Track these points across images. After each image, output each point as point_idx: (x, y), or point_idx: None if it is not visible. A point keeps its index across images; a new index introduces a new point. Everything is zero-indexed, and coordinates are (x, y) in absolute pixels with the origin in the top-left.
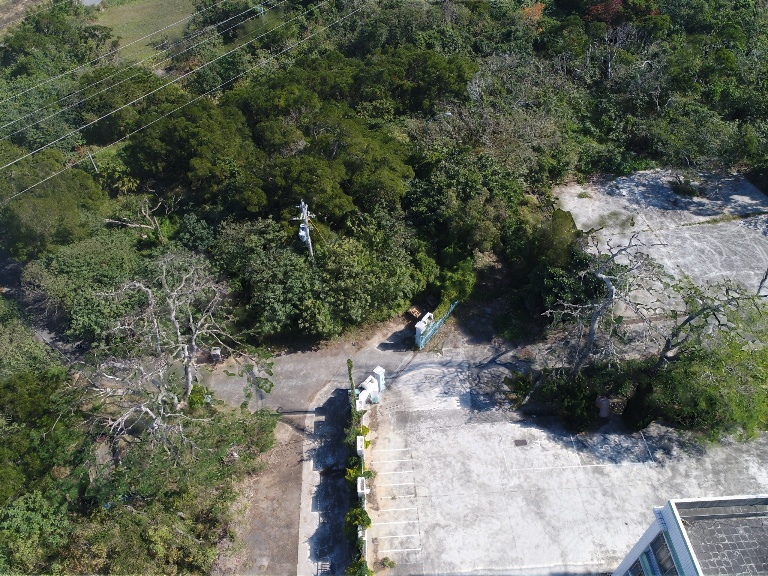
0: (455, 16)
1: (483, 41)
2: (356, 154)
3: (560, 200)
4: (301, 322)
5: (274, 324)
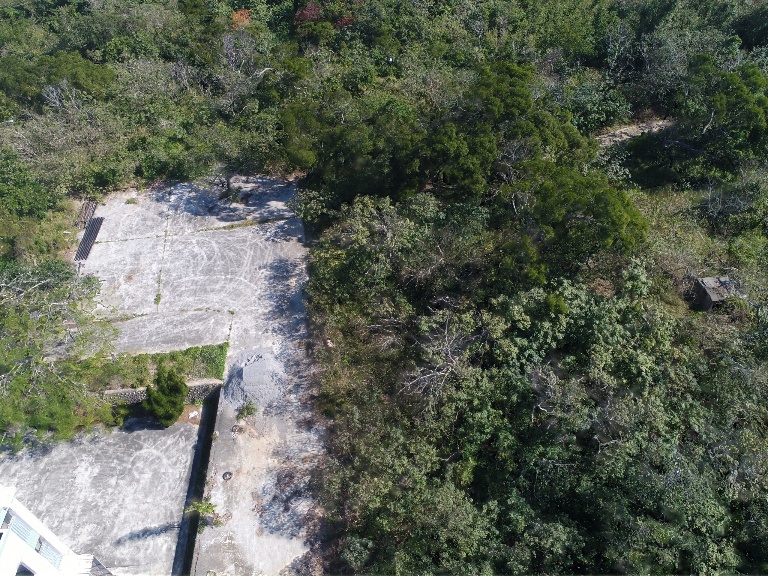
0: (163, 22)
1: (170, 47)
2: None
3: (106, 206)
4: None
5: None
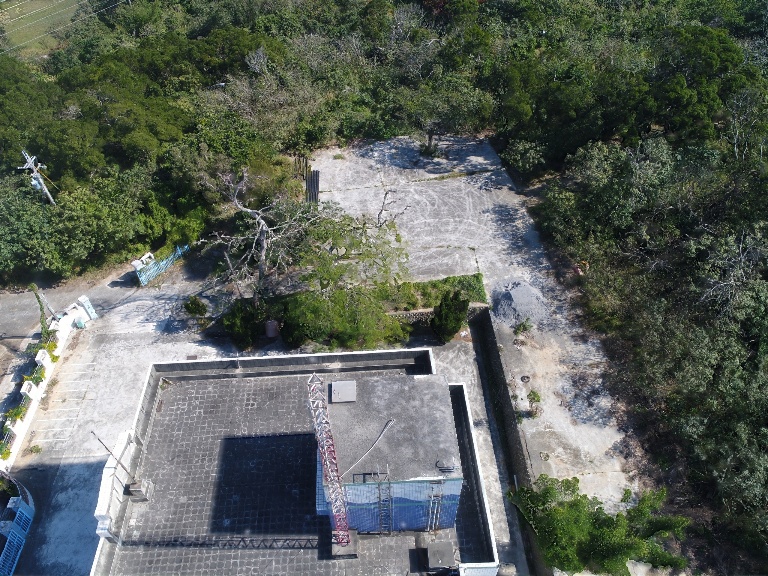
0: (300, 2)
1: (316, 24)
2: (118, 118)
3: (316, 161)
4: (29, 260)
5: (8, 262)
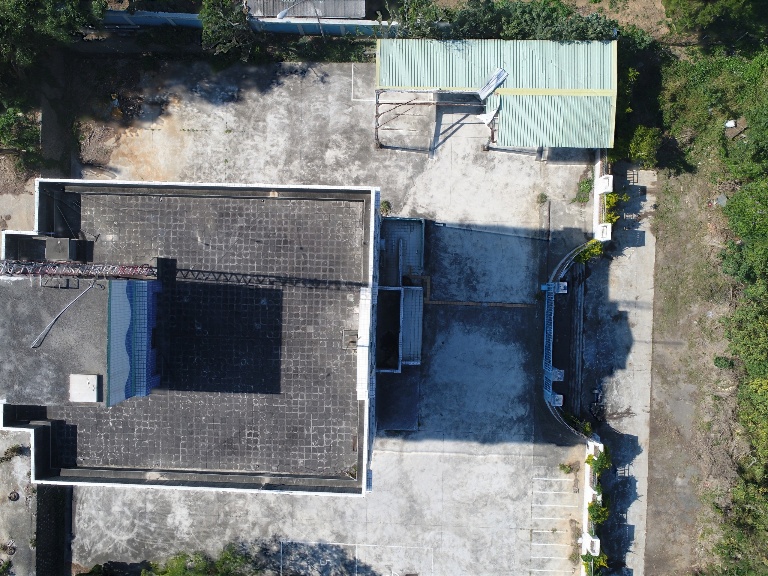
0: None
1: None
2: None
3: None
4: None
5: None
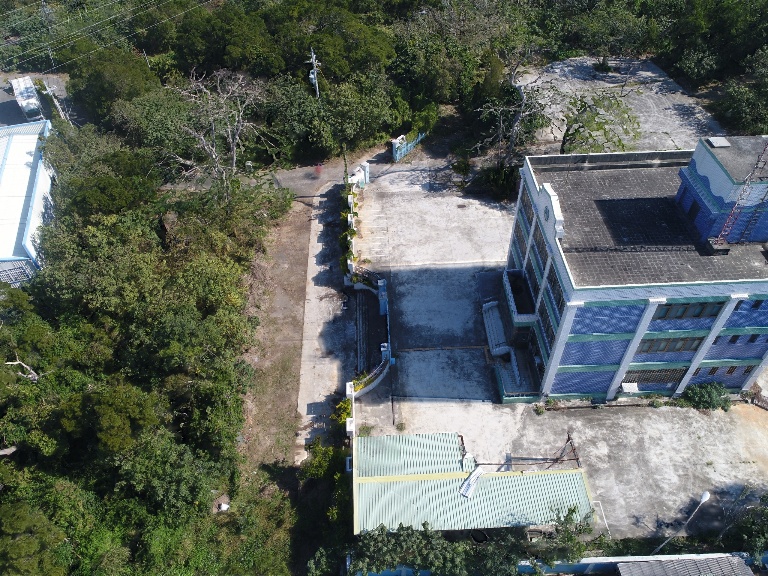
0: None
1: None
2: (352, 34)
3: None
4: (310, 137)
5: (291, 140)
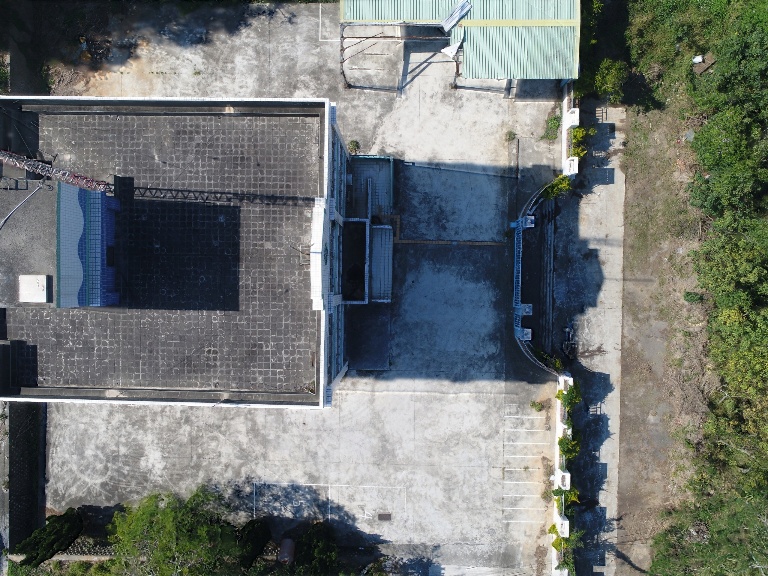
0: None
1: None
2: None
3: None
4: None
5: None
